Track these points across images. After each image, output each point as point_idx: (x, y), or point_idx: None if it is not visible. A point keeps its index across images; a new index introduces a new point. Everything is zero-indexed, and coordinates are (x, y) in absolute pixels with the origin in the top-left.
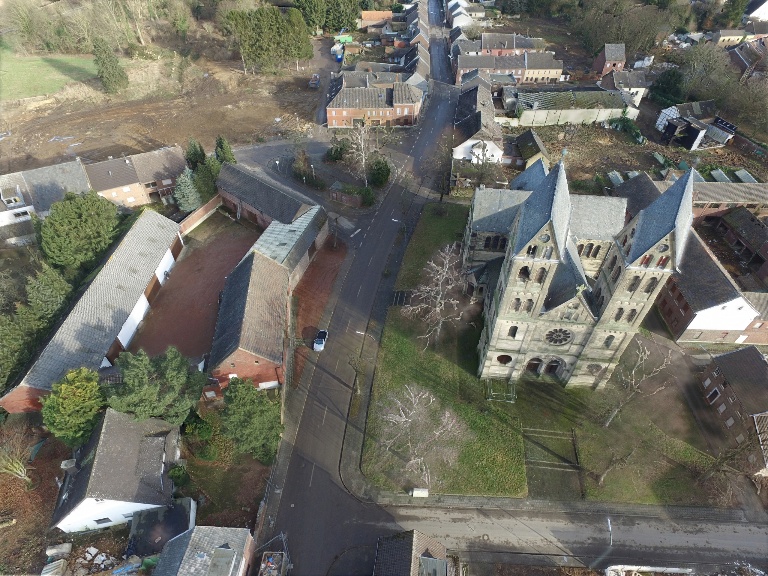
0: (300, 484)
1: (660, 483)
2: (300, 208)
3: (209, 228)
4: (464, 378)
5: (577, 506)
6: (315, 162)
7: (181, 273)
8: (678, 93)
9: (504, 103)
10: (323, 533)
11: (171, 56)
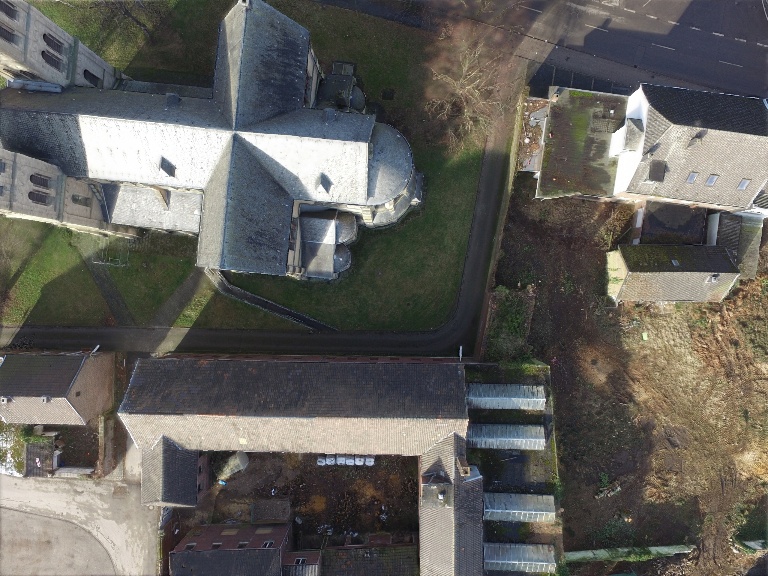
0: None
1: None
2: None
3: None
4: None
5: None
6: None
7: None
8: None
9: None
10: None
11: None
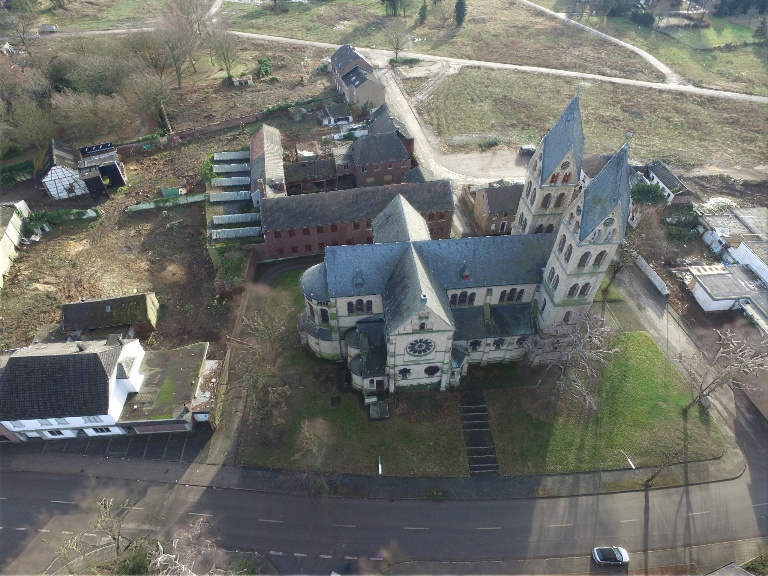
0: None
1: None
2: None
3: None
4: None
5: (632, 305)
6: None
7: None
8: None
9: None
10: None
11: None
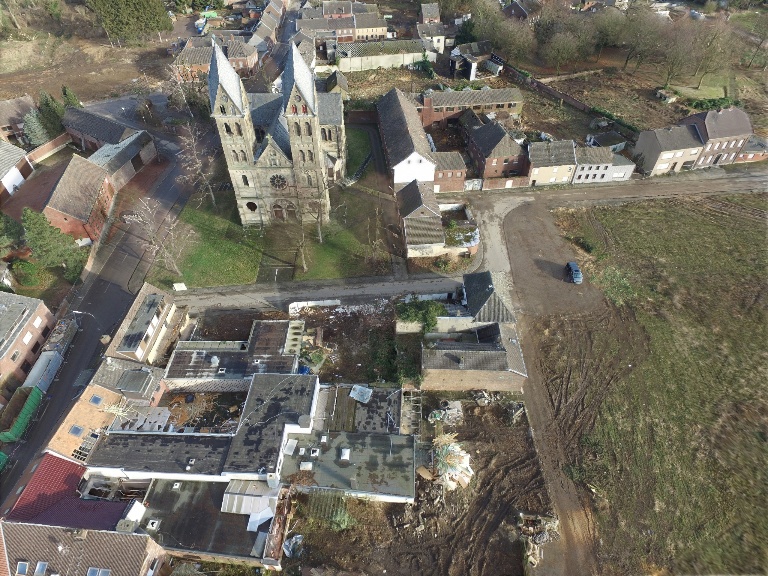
0: (97, 293)
1: (345, 267)
2: (125, 131)
3: (58, 158)
4: (231, 227)
5: (286, 284)
6: (159, 108)
7: (29, 187)
8: (475, 40)
9: (327, 54)
10: (108, 314)
11: (45, 37)
